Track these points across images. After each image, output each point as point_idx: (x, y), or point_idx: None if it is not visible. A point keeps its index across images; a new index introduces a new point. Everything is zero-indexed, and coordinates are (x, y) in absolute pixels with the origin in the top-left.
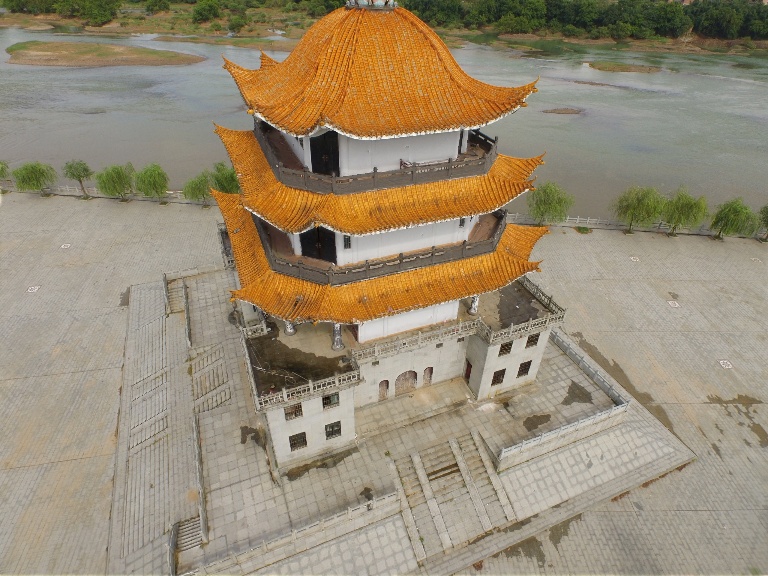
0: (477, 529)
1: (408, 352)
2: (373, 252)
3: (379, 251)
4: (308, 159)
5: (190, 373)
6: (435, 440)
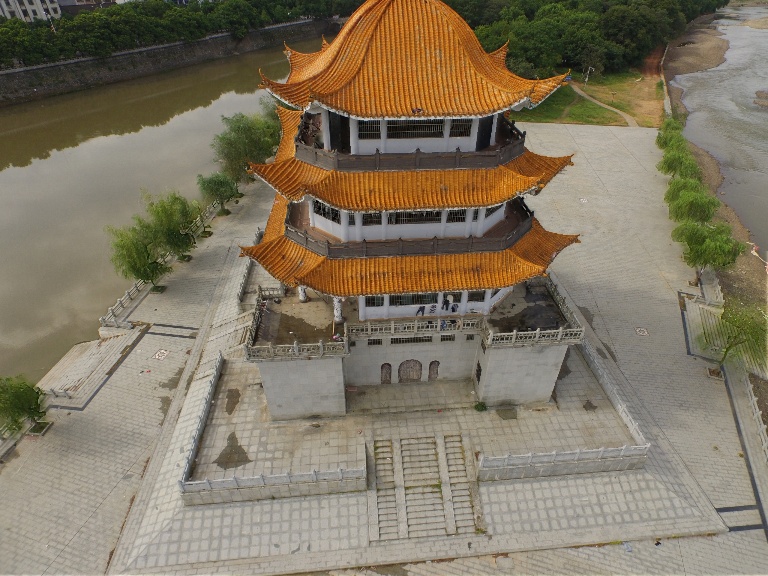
0: None
1: None
2: None
3: None
4: None
5: None
6: None
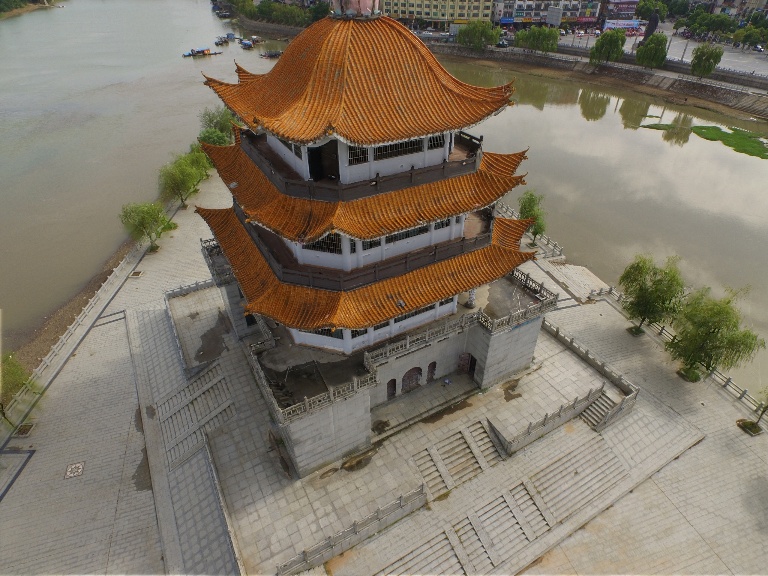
0: None
1: None
2: None
3: None
4: None
5: (447, 494)
6: None
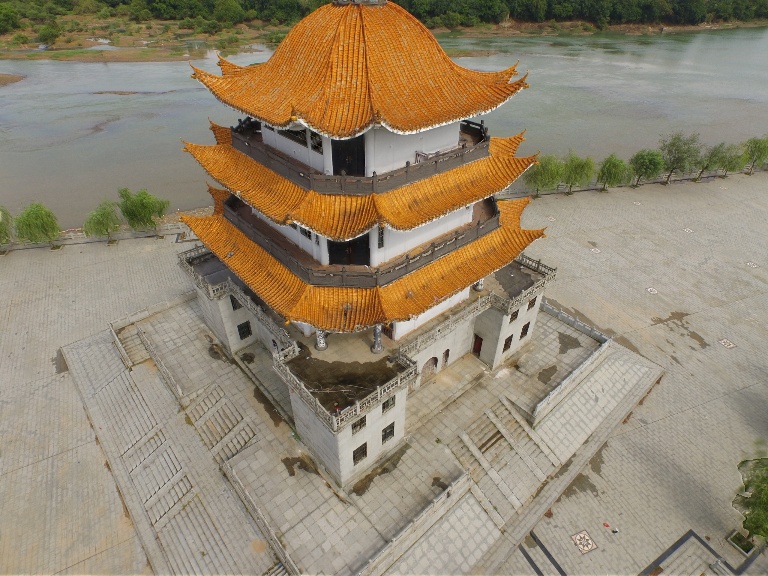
0: (535, 483)
1: None
2: (401, 247)
3: (405, 245)
4: (329, 163)
5: (190, 423)
6: (473, 415)
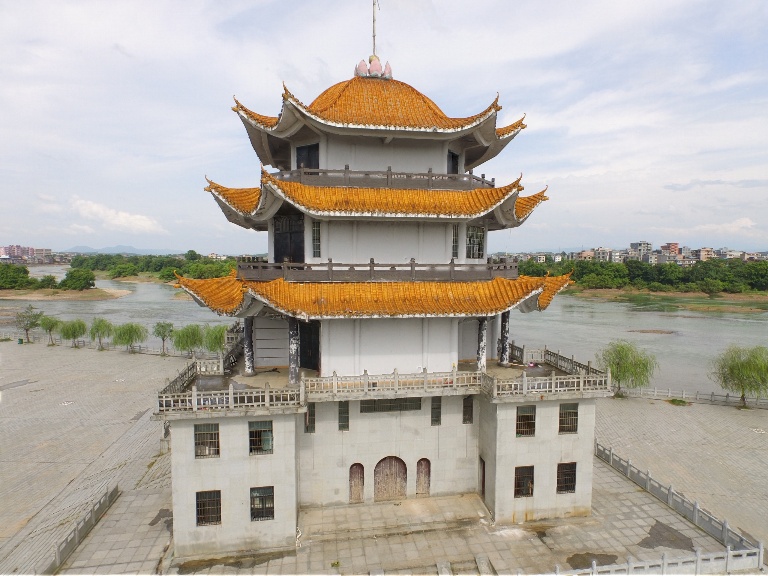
0: None
1: (390, 419)
2: None
3: None
4: None
5: (150, 466)
6: (415, 559)
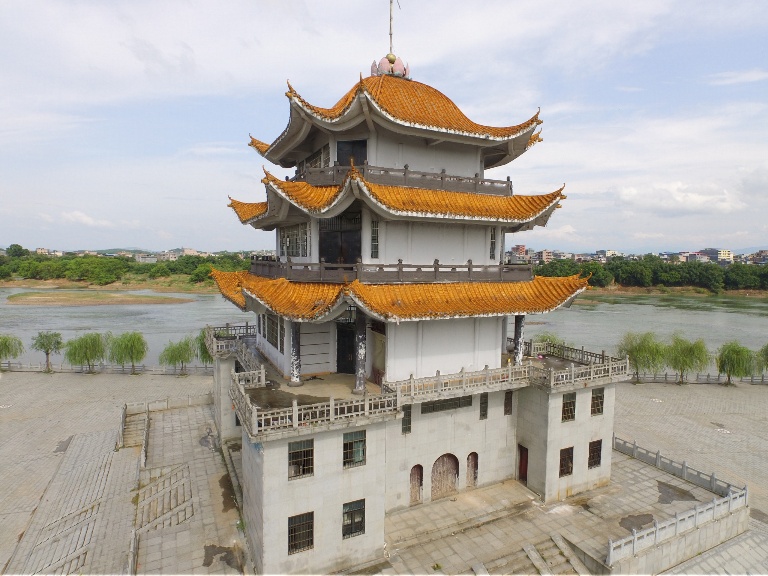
0: None
1: (447, 417)
2: None
3: None
4: None
5: (135, 502)
6: (503, 548)
